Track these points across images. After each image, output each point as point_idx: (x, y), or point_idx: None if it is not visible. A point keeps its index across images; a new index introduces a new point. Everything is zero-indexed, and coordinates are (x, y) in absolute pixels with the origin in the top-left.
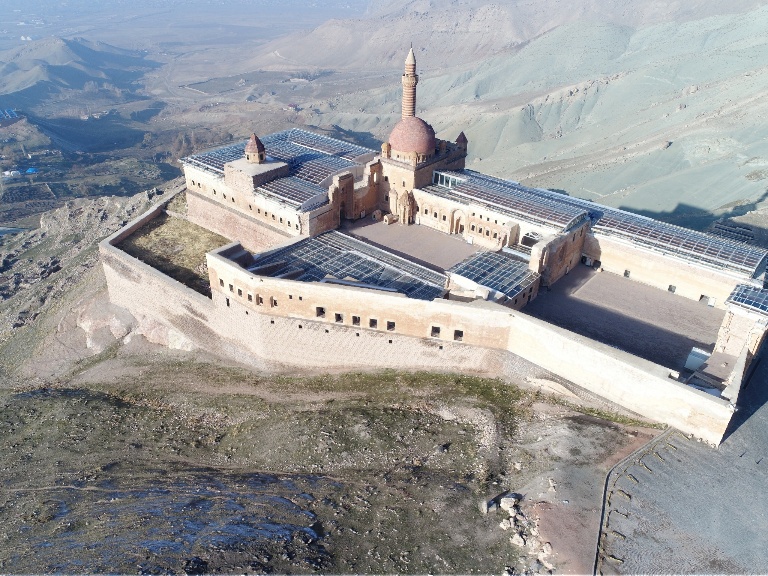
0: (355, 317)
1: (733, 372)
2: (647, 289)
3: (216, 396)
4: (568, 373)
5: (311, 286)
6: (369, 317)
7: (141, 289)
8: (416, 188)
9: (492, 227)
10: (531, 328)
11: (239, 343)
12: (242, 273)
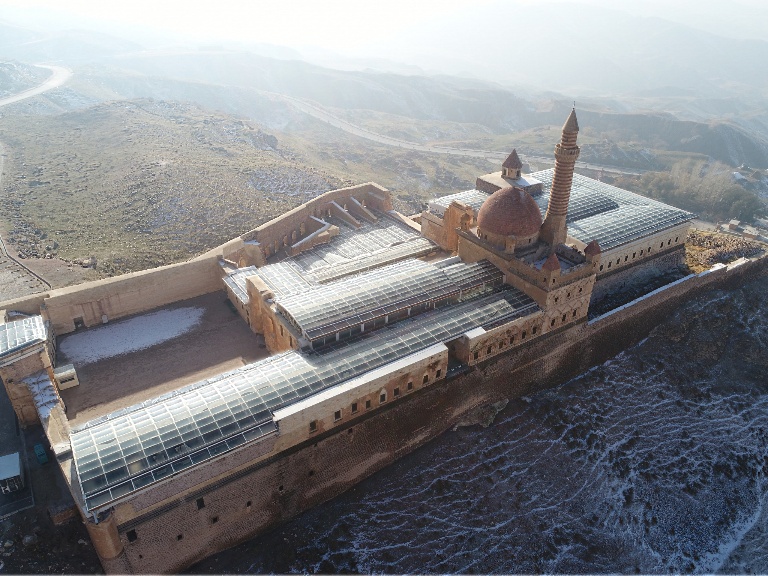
0: None
1: None
2: None
3: None
4: None
5: None
6: None
7: None
8: (461, 258)
9: None
10: None
11: None
12: None
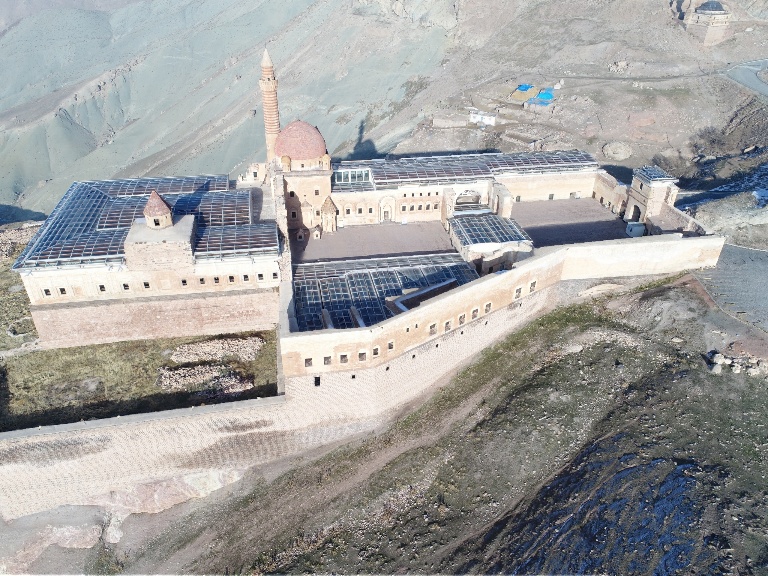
0: (461, 317)
1: (691, 220)
2: (539, 204)
3: (368, 482)
4: (615, 271)
5: (426, 307)
6: (472, 310)
7: (107, 457)
8: None
9: (426, 200)
10: (584, 251)
11: (332, 420)
12: (352, 333)
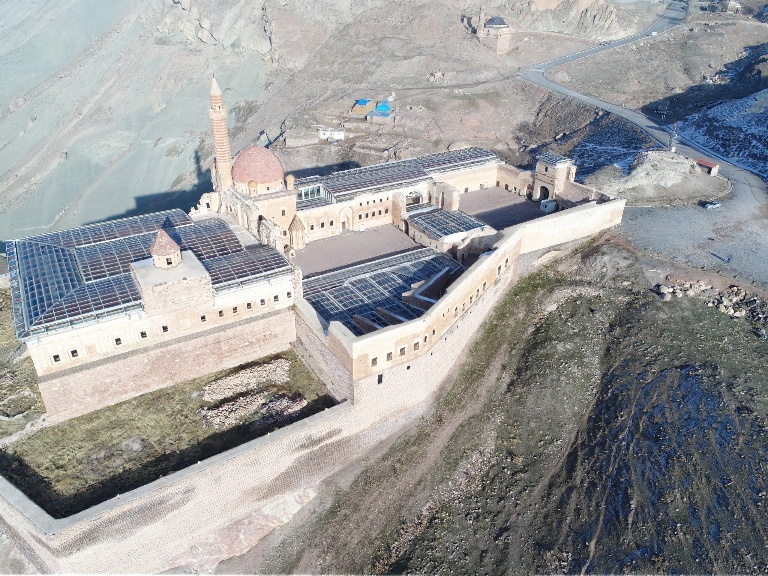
0: (470, 297)
1: (594, 190)
2: None
3: (441, 459)
4: (557, 240)
5: (453, 292)
6: None
7: (191, 509)
8: None
9: (378, 206)
10: (536, 227)
11: (390, 414)
12: (410, 326)
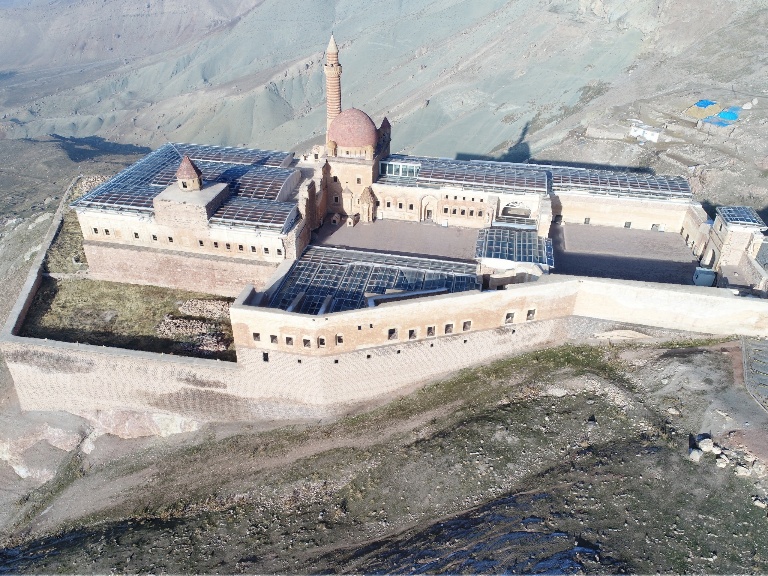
0: (430, 328)
1: (764, 277)
2: (609, 230)
3: (291, 466)
4: (640, 318)
5: (383, 309)
6: (445, 323)
7: (93, 379)
8: (373, 182)
9: (469, 205)
10: (602, 288)
11: (282, 399)
12: (296, 318)
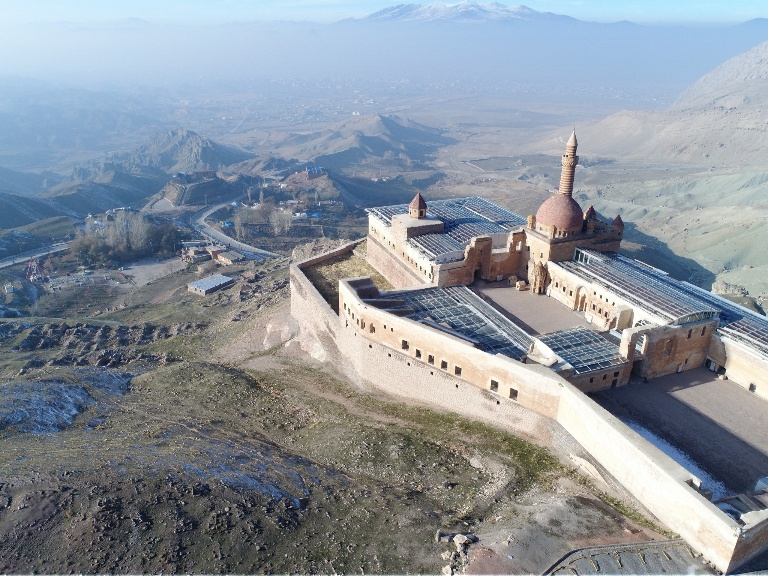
0: (431, 356)
1: None
2: None
3: (316, 398)
4: (600, 456)
5: (400, 320)
6: (441, 358)
7: (306, 305)
8: (552, 261)
9: (610, 309)
10: (575, 401)
11: (350, 361)
12: (355, 299)
